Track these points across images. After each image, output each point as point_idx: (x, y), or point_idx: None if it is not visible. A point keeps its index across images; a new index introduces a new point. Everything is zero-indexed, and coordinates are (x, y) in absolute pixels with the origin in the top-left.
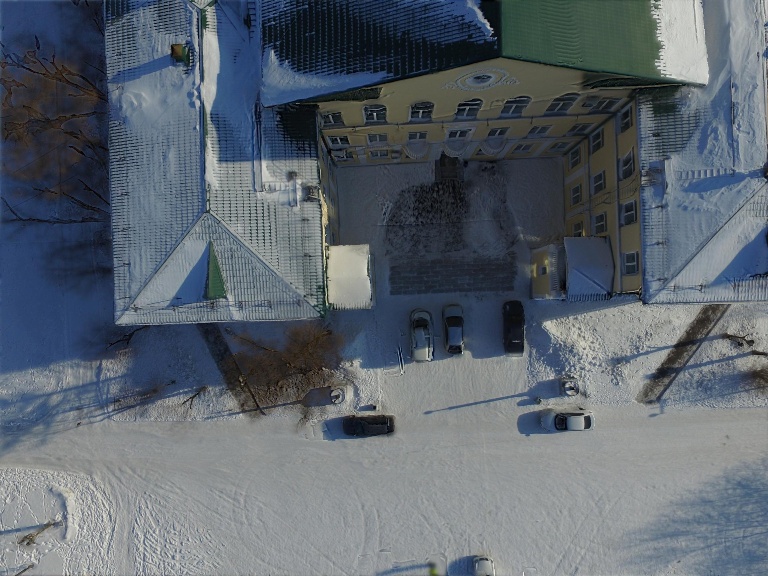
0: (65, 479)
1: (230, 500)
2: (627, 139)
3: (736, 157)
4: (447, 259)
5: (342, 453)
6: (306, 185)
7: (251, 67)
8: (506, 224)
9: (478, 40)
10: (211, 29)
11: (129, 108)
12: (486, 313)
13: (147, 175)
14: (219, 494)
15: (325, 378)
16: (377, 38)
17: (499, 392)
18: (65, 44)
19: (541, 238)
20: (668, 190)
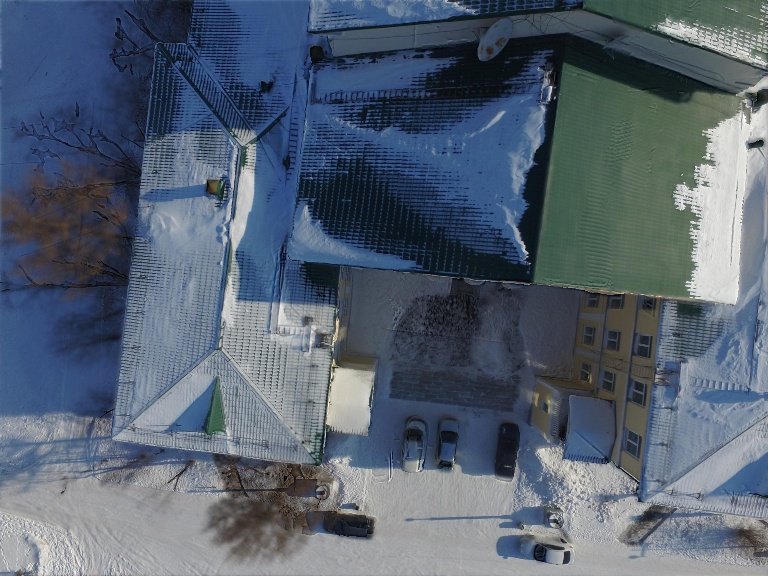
0: (42, 530)
1: (201, 575)
2: (647, 322)
3: (753, 376)
4: (451, 373)
5: (319, 547)
6: (321, 332)
7: (283, 209)
8: (515, 347)
9: (512, 260)
10: (249, 166)
11: (157, 229)
12: (482, 433)
13: (165, 298)
14: (191, 568)
15: (313, 470)
16: (412, 225)
17: (483, 511)
18: (105, 99)
19: (547, 367)
20: (680, 394)
